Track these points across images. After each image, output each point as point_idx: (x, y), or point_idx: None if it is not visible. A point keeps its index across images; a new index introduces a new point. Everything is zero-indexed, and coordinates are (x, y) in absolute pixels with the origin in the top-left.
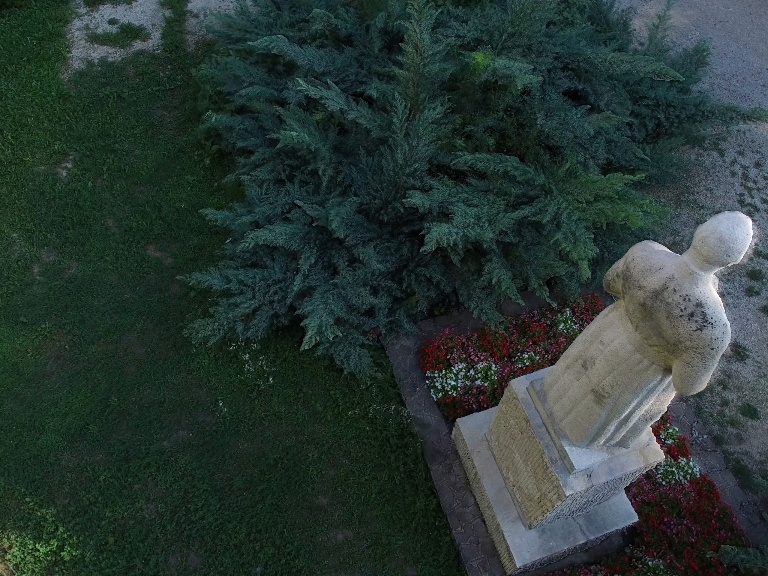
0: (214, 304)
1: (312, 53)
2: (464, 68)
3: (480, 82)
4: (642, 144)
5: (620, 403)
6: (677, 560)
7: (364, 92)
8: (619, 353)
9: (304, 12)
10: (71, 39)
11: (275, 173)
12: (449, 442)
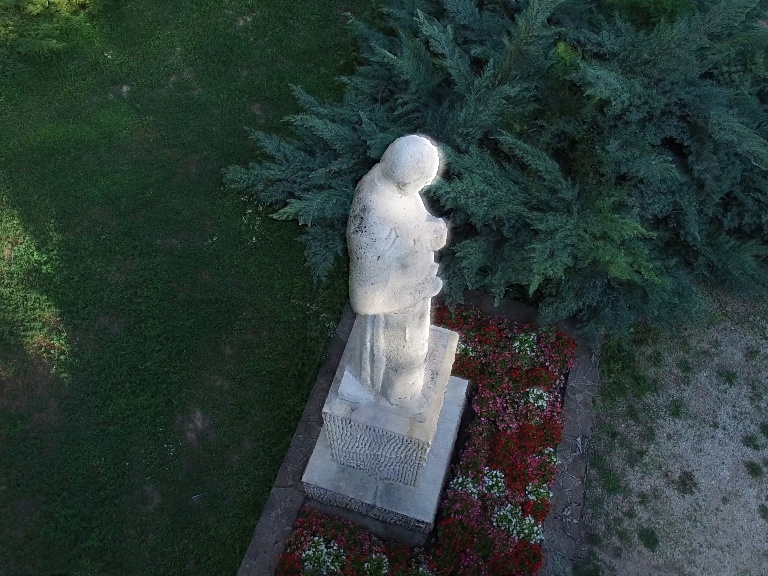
0: None
1: (466, 6)
2: None
3: (564, 80)
4: (730, 236)
5: (361, 328)
6: None
7: None
8: None
9: None
10: None
11: (374, 90)
12: None
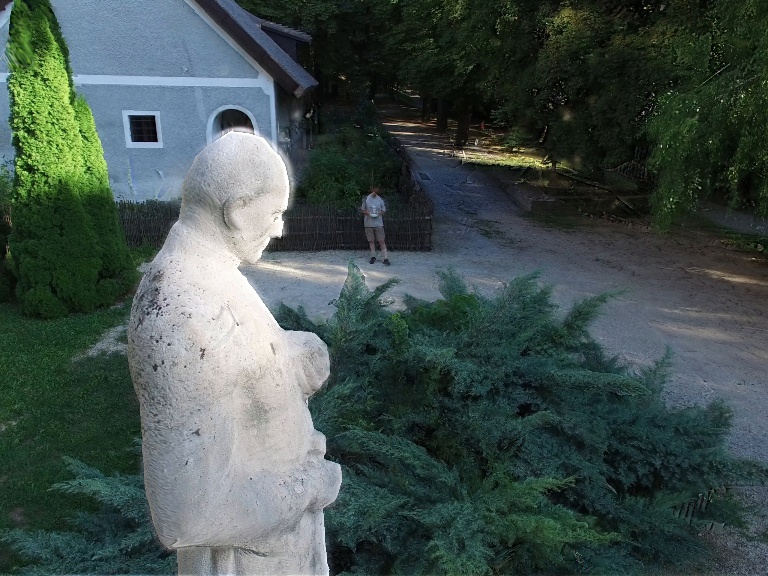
0: None
1: None
2: (409, 369)
3: (398, 361)
4: (635, 496)
5: None
6: None
7: None
8: None
9: None
10: (104, 336)
11: None
12: None
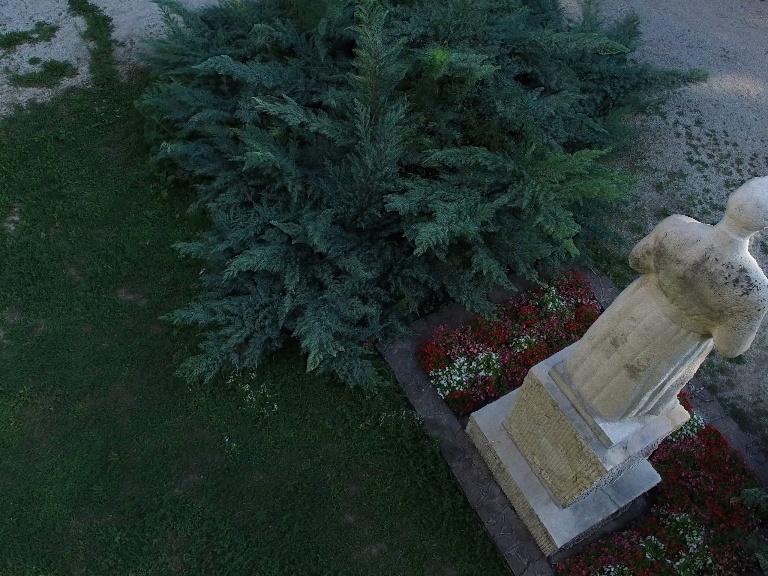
0: (200, 339)
1: (258, 69)
2: (415, 66)
3: (438, 78)
4: (593, 118)
5: (656, 374)
6: (702, 511)
7: (316, 102)
8: (654, 326)
9: (238, 28)
10: None
11: (240, 196)
12: (464, 437)
